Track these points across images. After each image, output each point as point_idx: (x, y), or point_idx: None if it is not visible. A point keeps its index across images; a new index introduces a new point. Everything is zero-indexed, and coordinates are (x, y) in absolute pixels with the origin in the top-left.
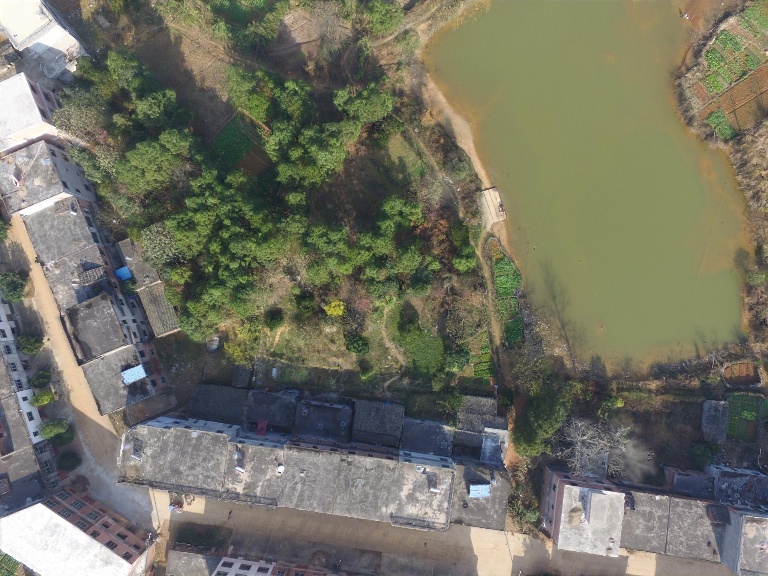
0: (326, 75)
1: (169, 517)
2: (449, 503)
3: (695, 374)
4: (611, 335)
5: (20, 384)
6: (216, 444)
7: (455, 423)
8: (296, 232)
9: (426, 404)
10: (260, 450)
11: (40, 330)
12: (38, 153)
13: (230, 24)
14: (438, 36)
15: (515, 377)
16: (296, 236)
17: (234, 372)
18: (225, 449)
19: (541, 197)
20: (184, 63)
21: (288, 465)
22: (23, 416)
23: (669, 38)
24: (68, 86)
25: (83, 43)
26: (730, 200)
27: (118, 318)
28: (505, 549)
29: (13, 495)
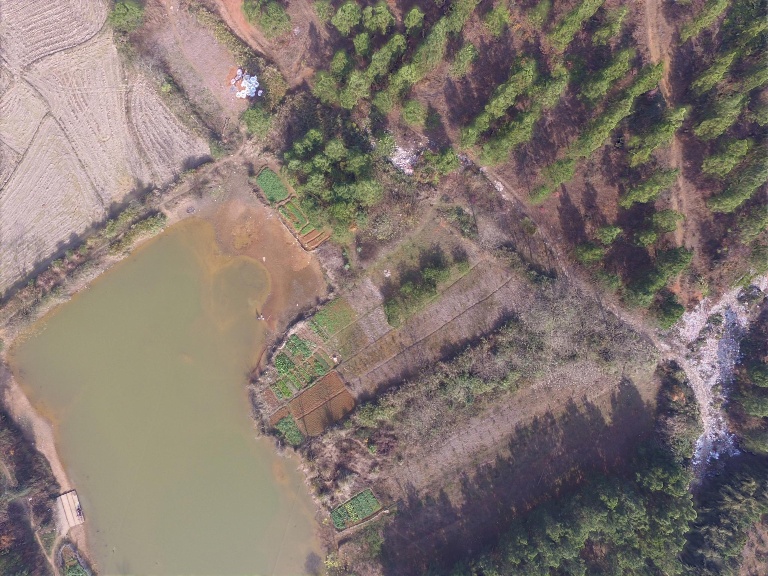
0: None
1: None
2: None
3: None
4: None
5: None
6: None
7: None
8: None
9: None
10: None
11: None
12: None
13: None
14: None
15: None
16: None
17: None
18: None
19: (121, 499)
20: None
21: None
22: None
23: (246, 339)
24: None
25: None
26: (303, 504)
27: None
28: None
29: None
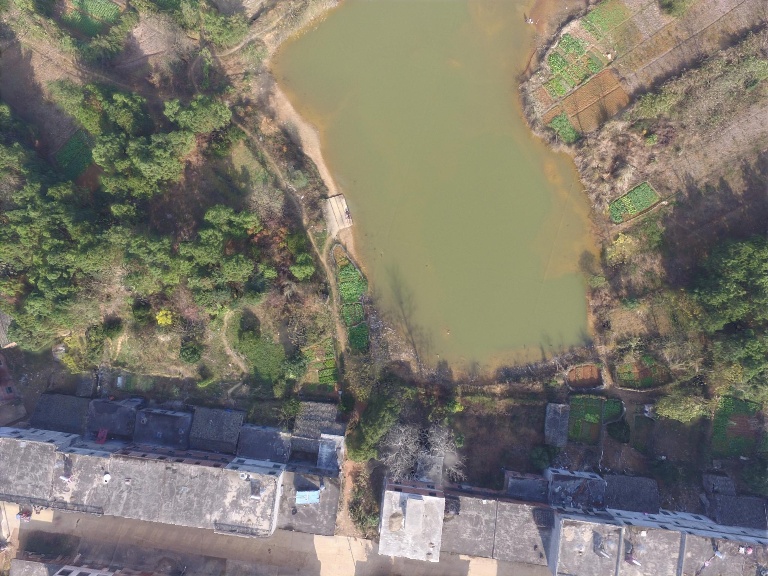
0: (171, 86)
1: (19, 526)
2: (272, 510)
3: (540, 377)
4: (457, 339)
5: None
6: (44, 454)
7: (292, 429)
8: (119, 243)
9: (268, 411)
10: (87, 459)
11: None
12: None
13: (76, 38)
14: (286, 45)
15: None
16: (119, 247)
17: (78, 381)
18: (53, 458)
19: (388, 203)
20: (33, 77)
21: (114, 474)
22: None
23: (514, 43)
24: None
25: None
26: (575, 203)
27: None
28: (348, 554)
29: None
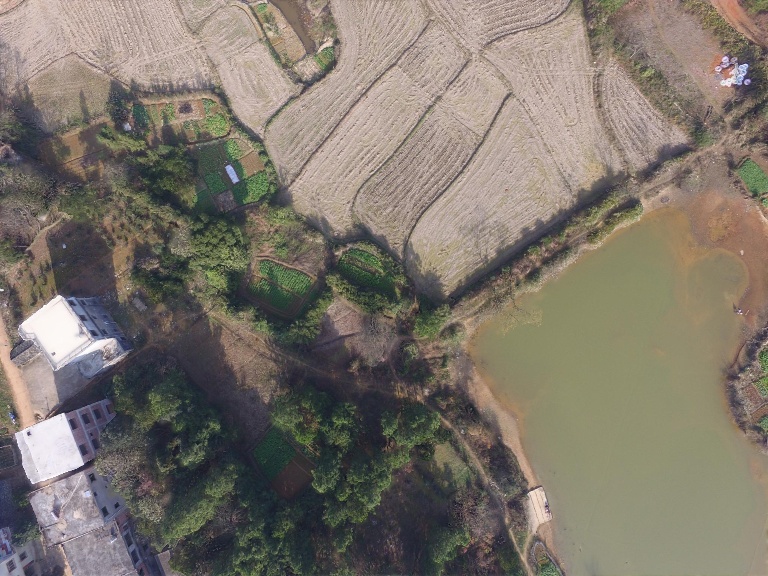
0: (371, 375)
1: None
2: None
3: None
4: None
5: None
6: None
7: None
8: None
9: None
10: None
11: None
12: (78, 485)
13: (272, 322)
14: (485, 326)
15: None
16: None
17: None
18: None
19: (588, 496)
20: (224, 357)
21: None
22: None
23: (722, 333)
24: (111, 428)
25: (119, 329)
26: None
27: None
28: None
29: None
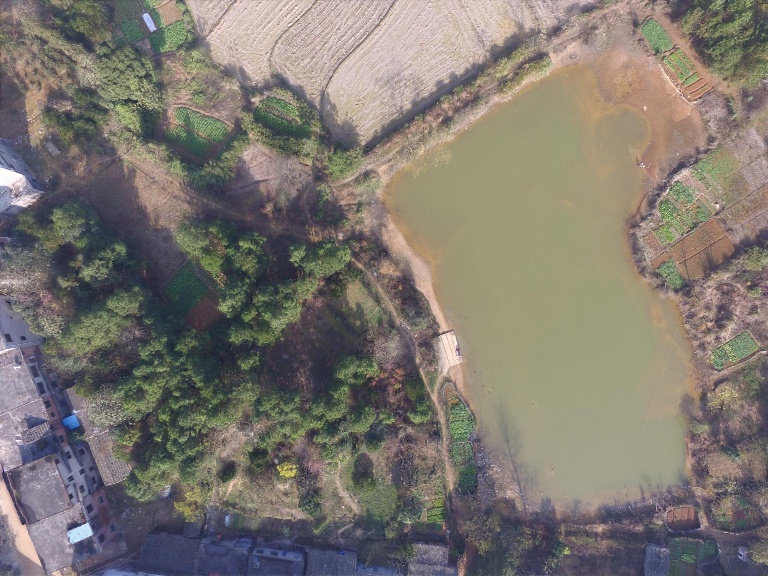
0: (285, 217)
1: None
2: None
3: (639, 517)
4: (561, 478)
5: None
6: None
7: (406, 575)
8: (248, 400)
9: (379, 551)
10: None
11: None
12: None
13: (186, 162)
14: (399, 176)
15: None
16: (248, 403)
17: None
18: None
19: (497, 340)
20: (138, 199)
21: None
22: None
23: (626, 185)
24: (10, 245)
25: (31, 172)
26: (678, 347)
27: (63, 480)
28: None
29: None
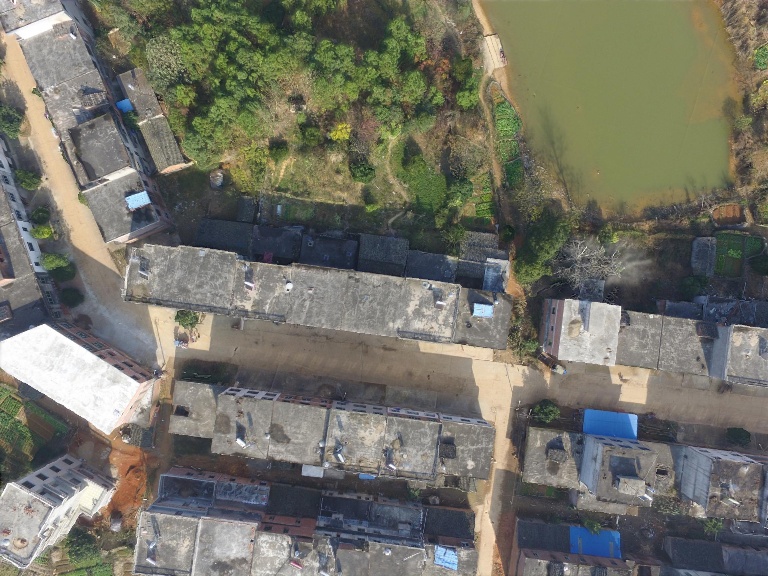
0: None
1: (174, 355)
2: (454, 318)
3: None
4: (607, 180)
5: (19, 215)
6: (224, 263)
7: (458, 253)
8: (303, 50)
9: (429, 240)
10: (268, 268)
11: (38, 169)
12: None
13: None
14: None
15: (515, 217)
16: (303, 54)
17: (239, 207)
18: (233, 267)
19: (541, 45)
20: None
21: (296, 283)
22: (24, 243)
23: None
24: None
25: None
26: (720, 51)
27: (122, 140)
28: (505, 380)
29: (15, 323)
